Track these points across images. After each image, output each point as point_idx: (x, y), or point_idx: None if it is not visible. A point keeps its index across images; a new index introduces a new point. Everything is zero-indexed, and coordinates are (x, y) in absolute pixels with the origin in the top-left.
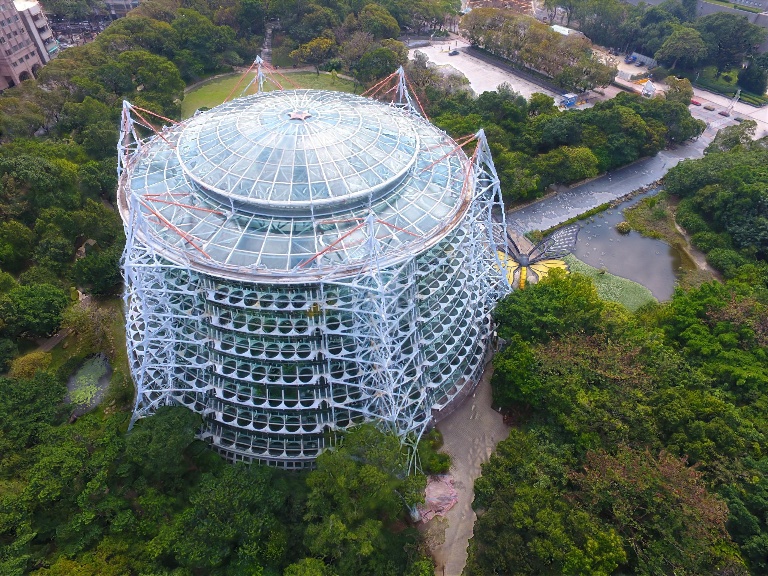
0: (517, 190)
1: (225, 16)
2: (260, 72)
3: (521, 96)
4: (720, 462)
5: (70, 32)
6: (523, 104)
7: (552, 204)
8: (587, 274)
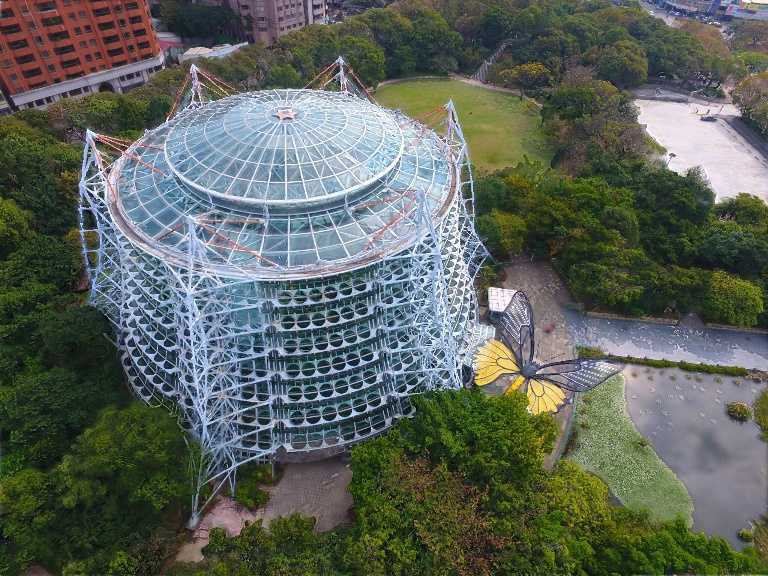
0: (606, 293)
1: (465, 23)
2: (340, 72)
3: (710, 189)
4: None
5: (354, 14)
6: (708, 200)
7: (659, 332)
8: (619, 433)
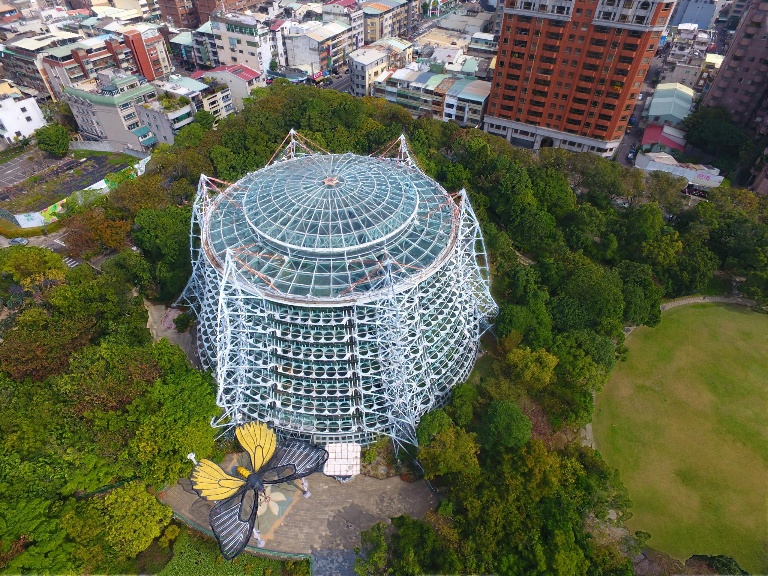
0: None
1: None
2: (462, 201)
3: None
4: (4, 402)
5: None
6: None
7: None
8: None
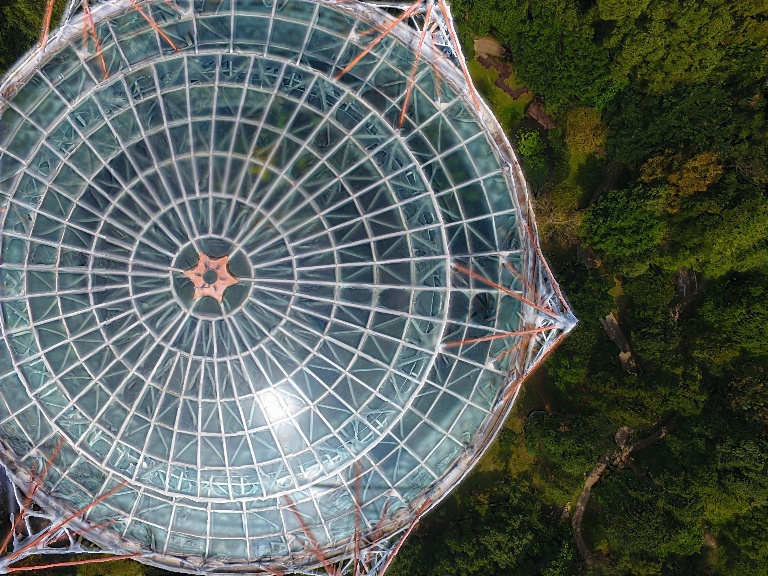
0: None
1: None
2: None
3: None
4: None
5: None
6: None
7: None
8: None
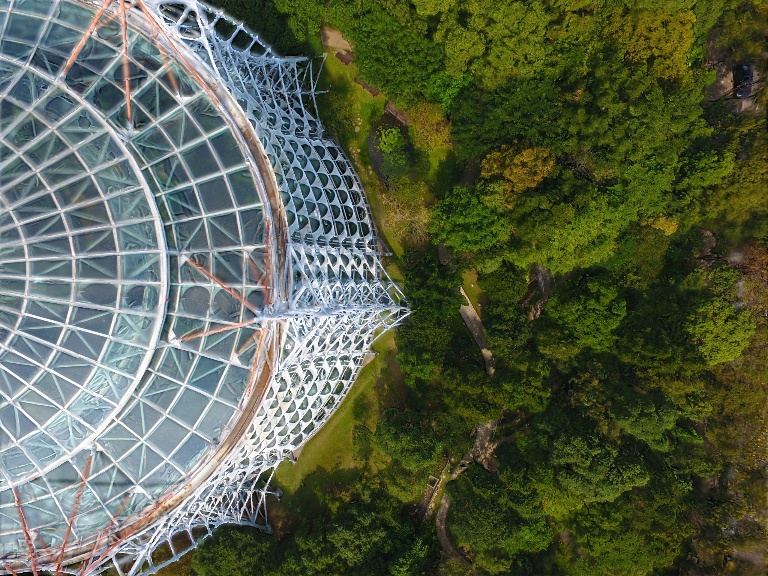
0: None
1: None
2: None
3: None
4: None
5: None
6: None
7: None
8: None
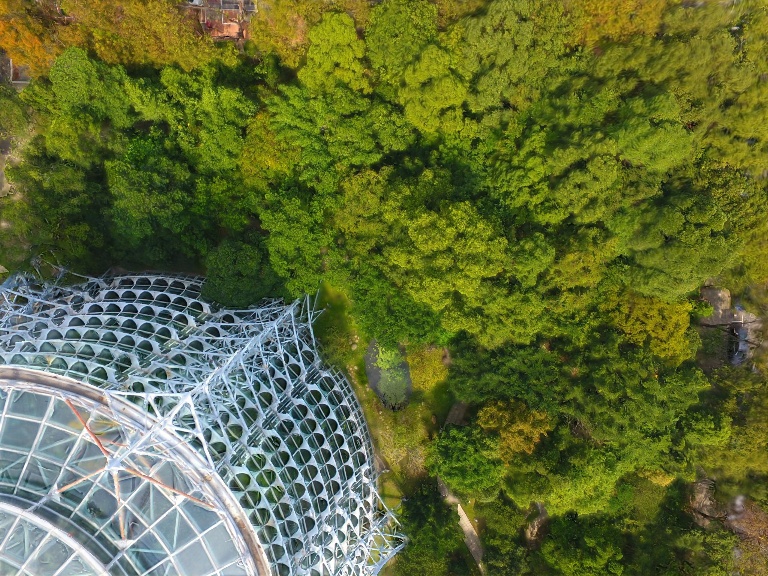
0: None
1: None
2: None
3: None
4: None
5: None
6: None
7: None
8: None
